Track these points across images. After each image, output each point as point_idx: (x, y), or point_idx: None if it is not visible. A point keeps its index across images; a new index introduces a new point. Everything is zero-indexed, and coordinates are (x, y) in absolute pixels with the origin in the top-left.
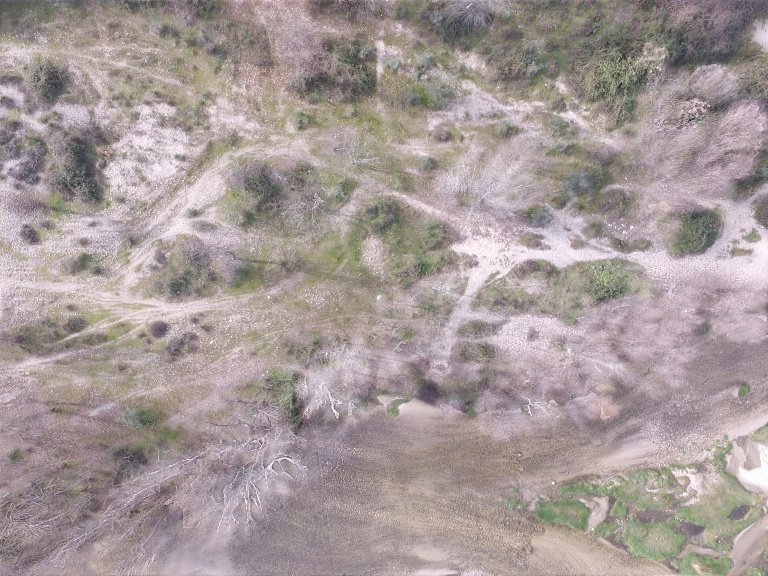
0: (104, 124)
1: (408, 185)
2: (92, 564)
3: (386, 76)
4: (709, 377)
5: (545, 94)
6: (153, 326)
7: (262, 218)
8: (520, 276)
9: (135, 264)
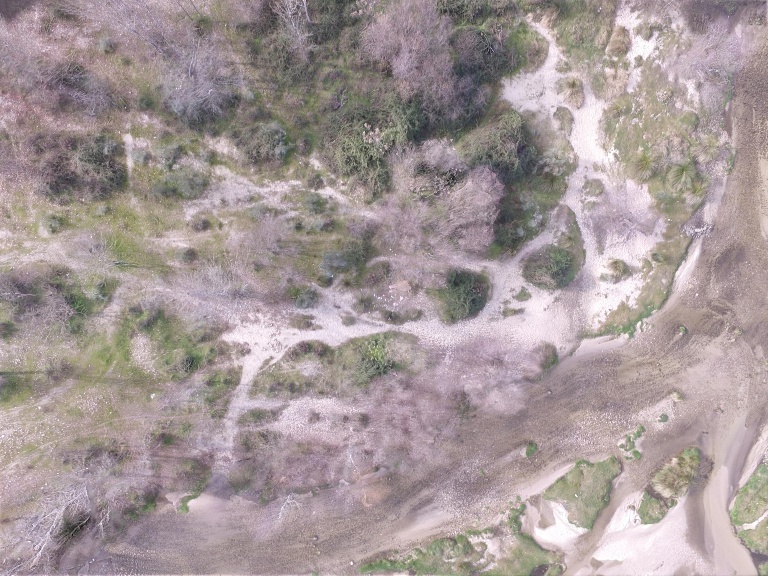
0: None
1: (171, 278)
2: None
3: (137, 169)
4: (496, 439)
5: (300, 172)
6: None
7: (23, 328)
8: (294, 359)
9: None
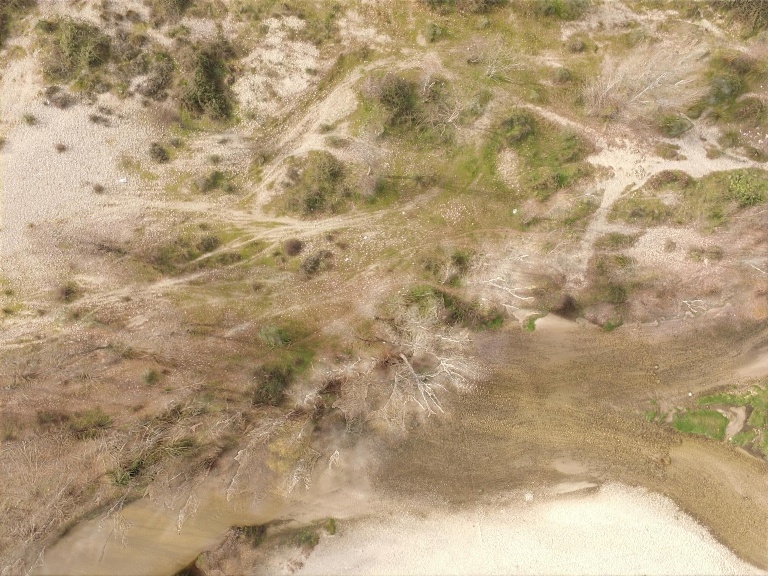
0: (232, 38)
1: (542, 97)
2: (269, 464)
3: None
4: None
5: (679, 2)
6: (289, 243)
7: (396, 132)
8: (656, 187)
9: (267, 182)
